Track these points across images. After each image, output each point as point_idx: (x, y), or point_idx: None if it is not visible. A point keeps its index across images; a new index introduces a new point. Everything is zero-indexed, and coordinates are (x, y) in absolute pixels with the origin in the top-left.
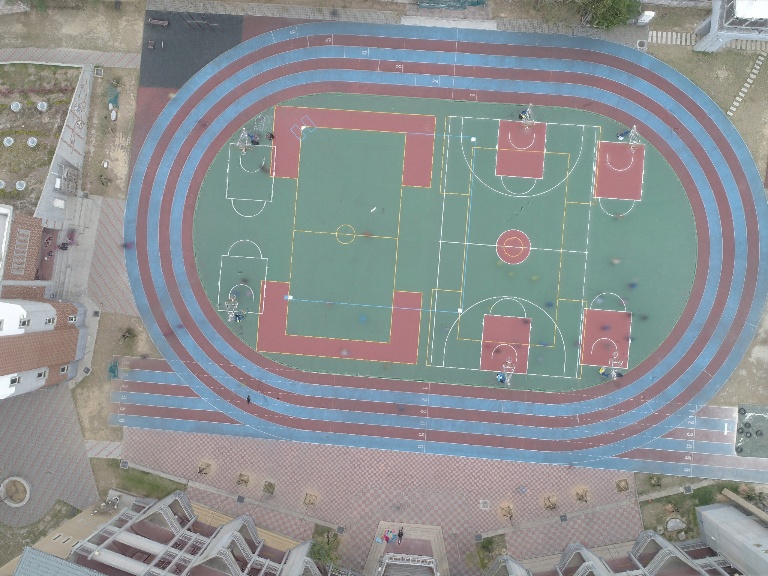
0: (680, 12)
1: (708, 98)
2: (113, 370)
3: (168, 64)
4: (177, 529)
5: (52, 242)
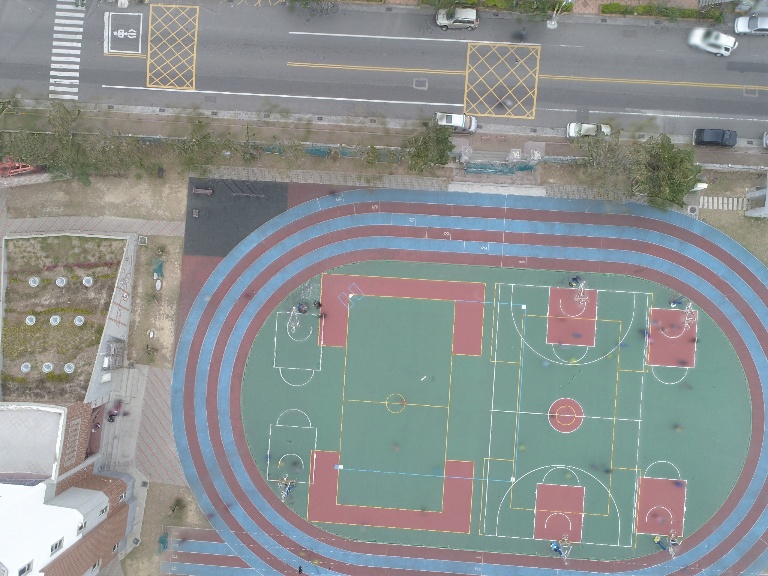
0: (731, 176)
1: (761, 264)
2: (163, 541)
3: (213, 232)
4: None
5: (99, 414)
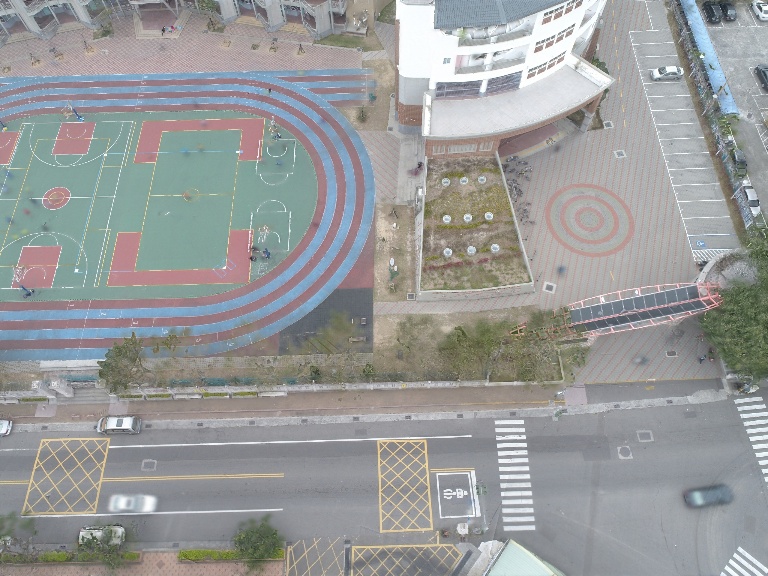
0: None
1: None
2: (373, 98)
3: (347, 308)
4: (303, 4)
5: None
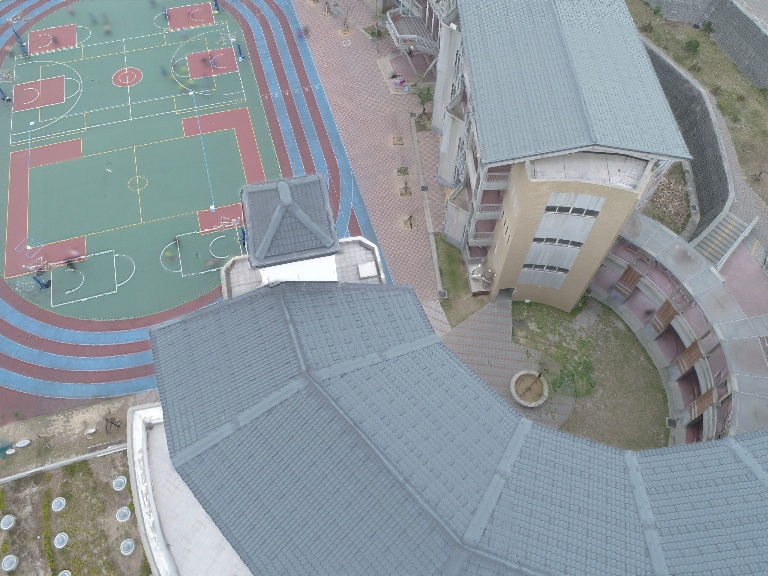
0: None
1: None
2: None
3: None
4: None
5: None
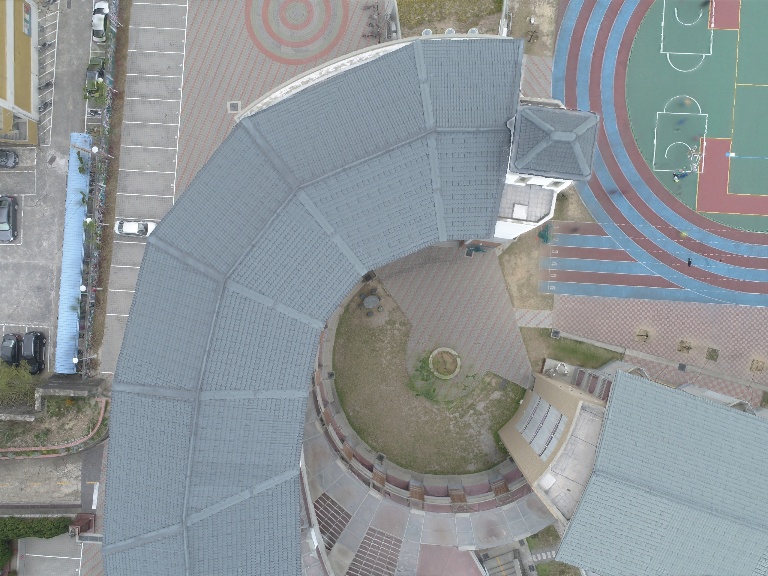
0: None
1: None
2: (542, 235)
3: None
4: None
5: None
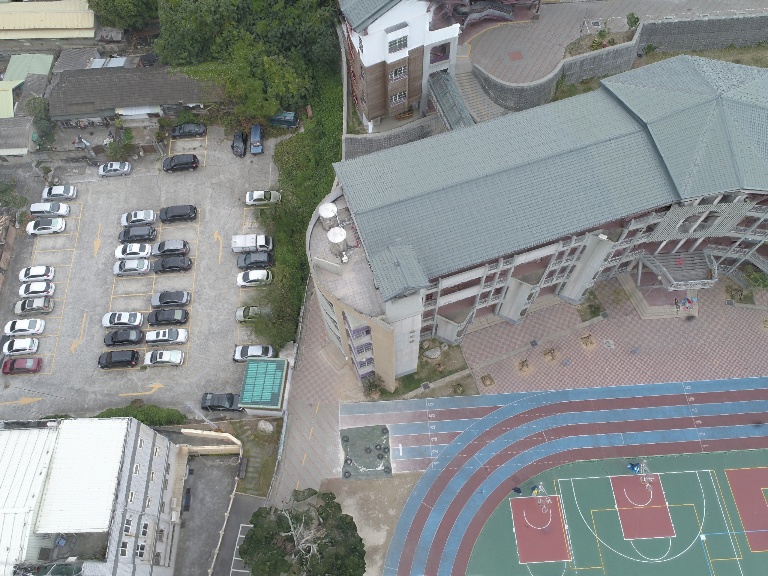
0: None
1: None
2: None
3: None
4: None
5: None
